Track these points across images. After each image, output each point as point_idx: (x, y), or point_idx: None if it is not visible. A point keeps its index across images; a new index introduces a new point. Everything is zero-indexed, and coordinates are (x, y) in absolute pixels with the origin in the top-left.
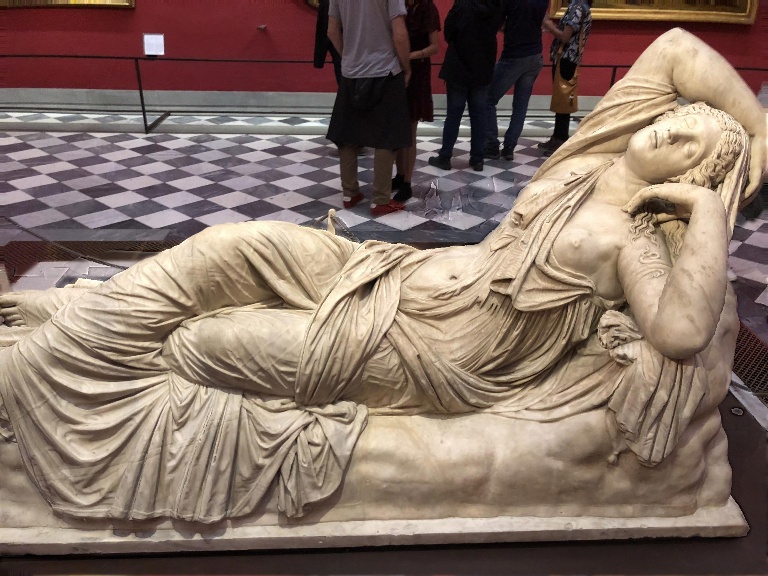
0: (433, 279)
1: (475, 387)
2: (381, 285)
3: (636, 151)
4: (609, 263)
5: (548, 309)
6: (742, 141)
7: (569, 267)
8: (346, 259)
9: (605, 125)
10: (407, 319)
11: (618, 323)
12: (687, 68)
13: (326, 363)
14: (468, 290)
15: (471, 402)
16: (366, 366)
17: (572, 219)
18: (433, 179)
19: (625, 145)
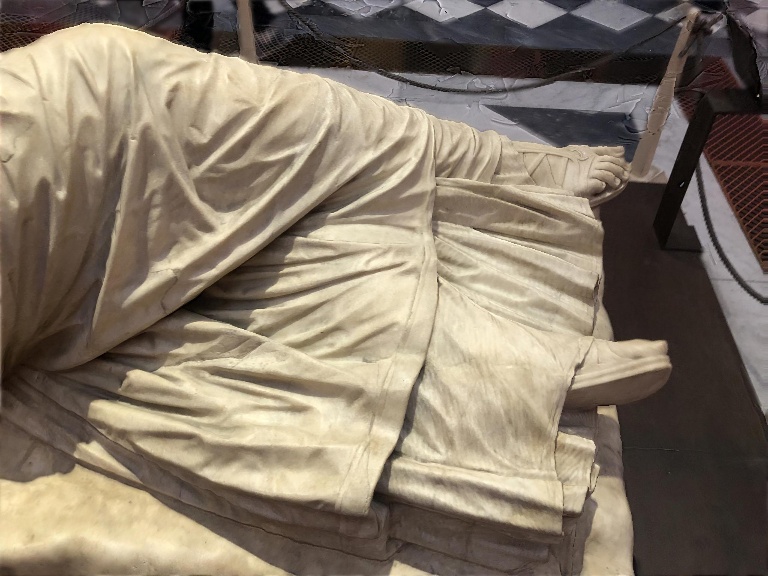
0: None
1: None
2: None
3: None
4: None
5: None
6: None
7: None
8: None
9: None
10: None
11: None
12: None
13: None
14: None
15: None
16: None
17: None
18: None
19: None
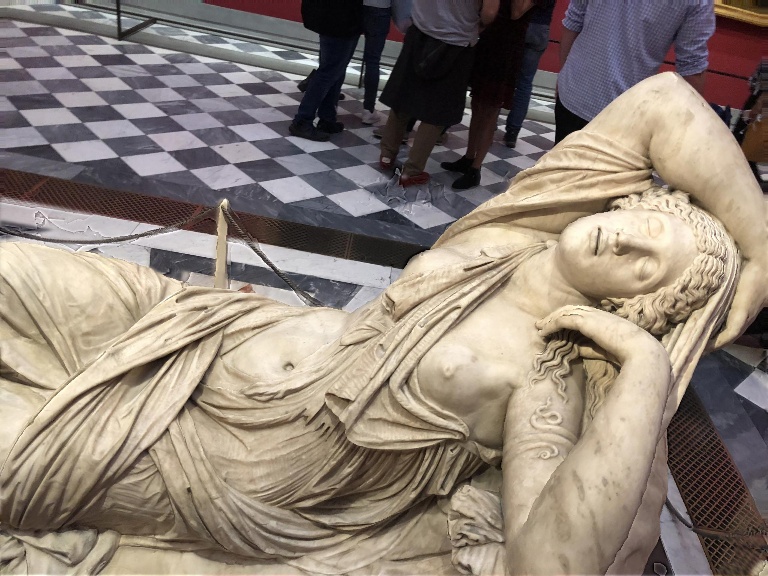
0: (258, 364)
1: (277, 533)
2: (176, 364)
3: (566, 252)
4: (496, 402)
5: (396, 449)
6: (727, 269)
7: (434, 400)
8: (141, 314)
9: (542, 193)
10: (192, 427)
11: (472, 515)
12: (672, 139)
13: (37, 487)
14: (296, 395)
15: (267, 552)
16: (109, 491)
17: (460, 325)
18: (399, 164)
19: (567, 225)
